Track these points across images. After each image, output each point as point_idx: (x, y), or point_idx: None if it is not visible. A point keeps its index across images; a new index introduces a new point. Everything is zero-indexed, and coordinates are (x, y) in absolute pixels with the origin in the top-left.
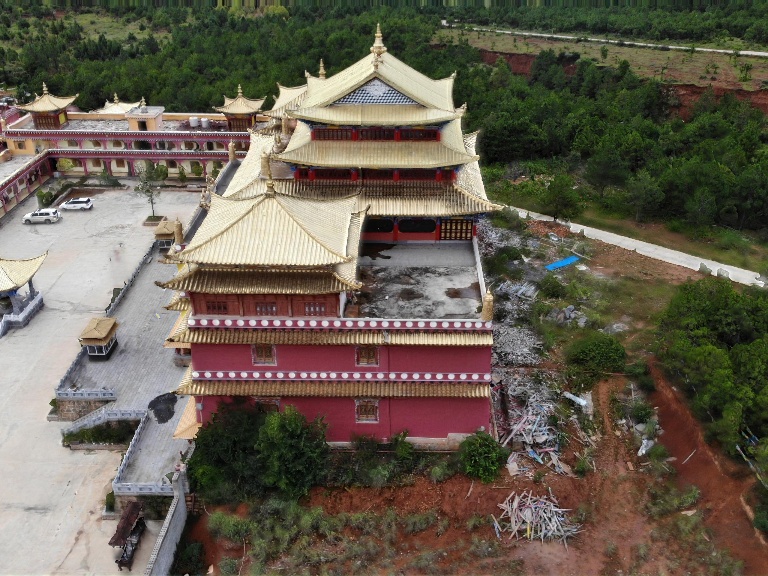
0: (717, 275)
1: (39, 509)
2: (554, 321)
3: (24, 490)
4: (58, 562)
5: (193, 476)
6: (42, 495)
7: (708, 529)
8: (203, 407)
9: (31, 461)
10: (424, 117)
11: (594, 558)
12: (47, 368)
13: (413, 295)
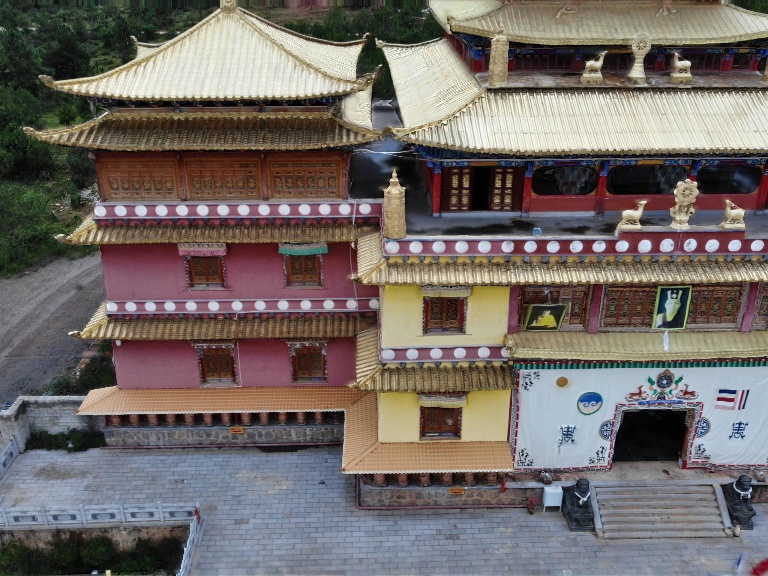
0: None
1: None
2: None
3: None
4: None
5: None
6: None
7: None
8: None
9: None
10: None
11: None
12: None
13: None
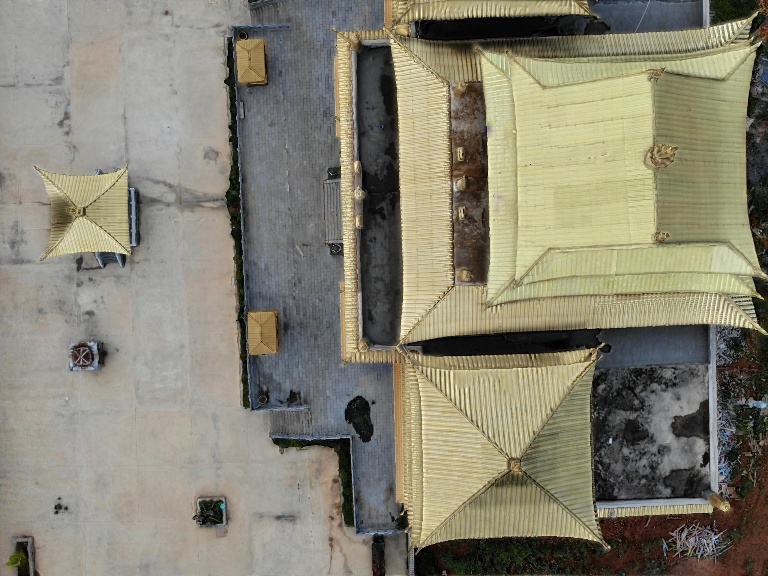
0: None
1: (287, 517)
2: (760, 283)
3: (265, 497)
4: (326, 568)
5: None
6: (282, 502)
7: None
8: None
9: (253, 462)
10: (706, 266)
11: (734, 571)
12: (202, 323)
13: (637, 434)
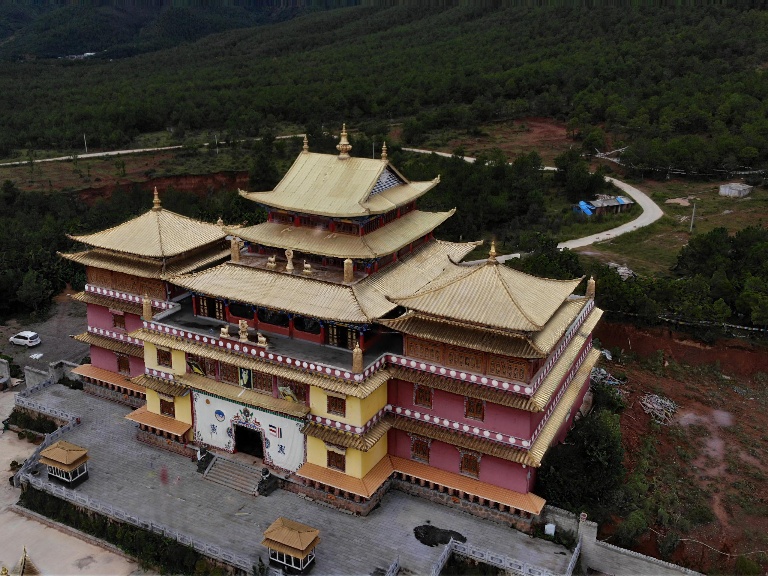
0: None
1: None
2: None
3: None
4: None
5: None
6: None
7: None
8: (530, 474)
9: None
10: (417, 191)
11: (692, 403)
12: None
13: None
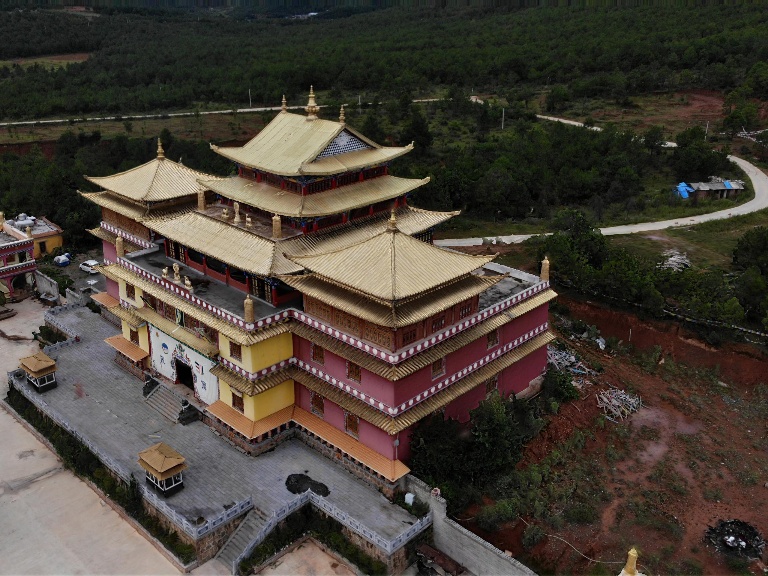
0: (496, 242)
1: None
2: None
3: None
4: None
5: (443, 495)
6: None
7: (681, 362)
8: (399, 442)
9: None
10: (383, 156)
11: (663, 405)
12: (90, 544)
13: None
